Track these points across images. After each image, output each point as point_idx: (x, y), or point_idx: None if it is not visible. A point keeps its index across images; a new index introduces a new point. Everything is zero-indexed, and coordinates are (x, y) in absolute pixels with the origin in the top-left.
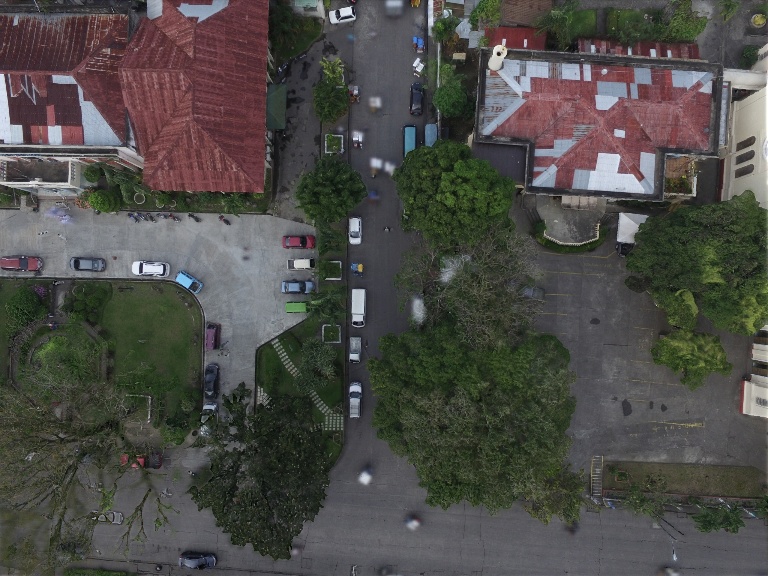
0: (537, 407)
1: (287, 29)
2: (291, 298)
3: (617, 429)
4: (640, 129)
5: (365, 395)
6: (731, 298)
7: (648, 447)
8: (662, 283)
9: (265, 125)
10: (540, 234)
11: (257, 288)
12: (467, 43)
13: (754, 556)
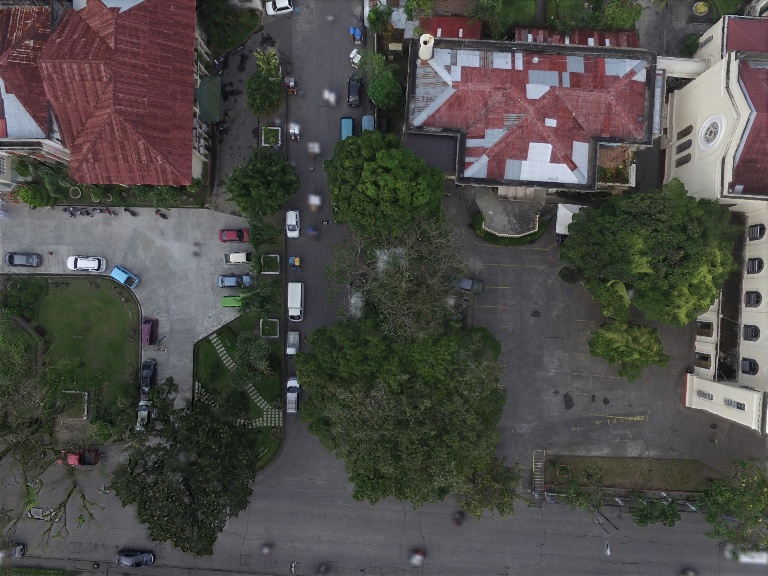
0: (459, 399)
1: (218, 20)
2: (229, 292)
3: (559, 423)
4: (572, 118)
5: (304, 390)
6: (661, 288)
7: (590, 441)
8: (593, 274)
9: (198, 117)
10: (479, 226)
11: (195, 283)
12: (403, 33)
13: (698, 551)
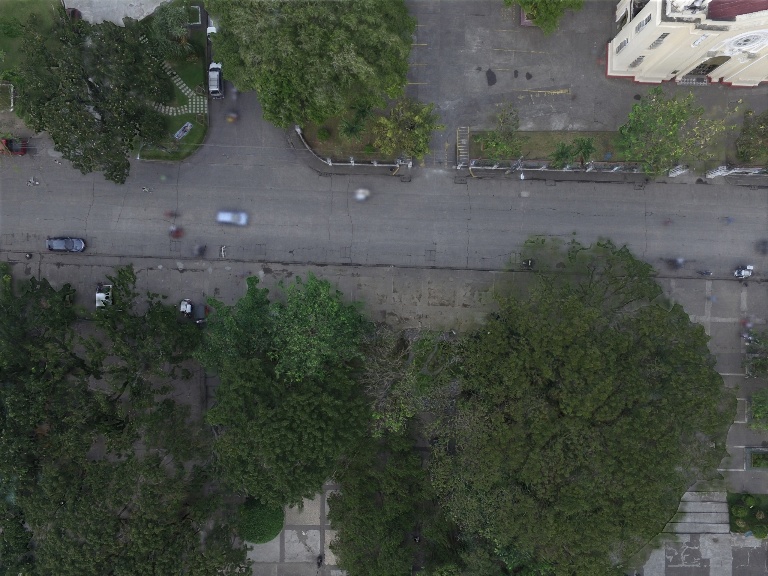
0: None
1: None
2: None
3: (482, 99)
4: None
5: None
6: None
7: None
8: None
9: None
10: None
11: None
12: None
13: (624, 220)
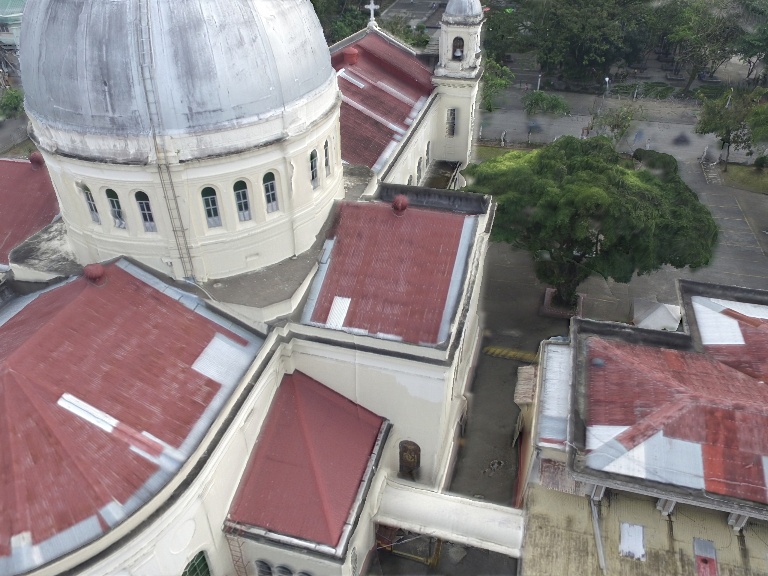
0: None
1: None
2: None
3: None
4: (763, 377)
5: None
6: None
7: None
8: None
9: None
10: None
11: None
12: None
13: None
